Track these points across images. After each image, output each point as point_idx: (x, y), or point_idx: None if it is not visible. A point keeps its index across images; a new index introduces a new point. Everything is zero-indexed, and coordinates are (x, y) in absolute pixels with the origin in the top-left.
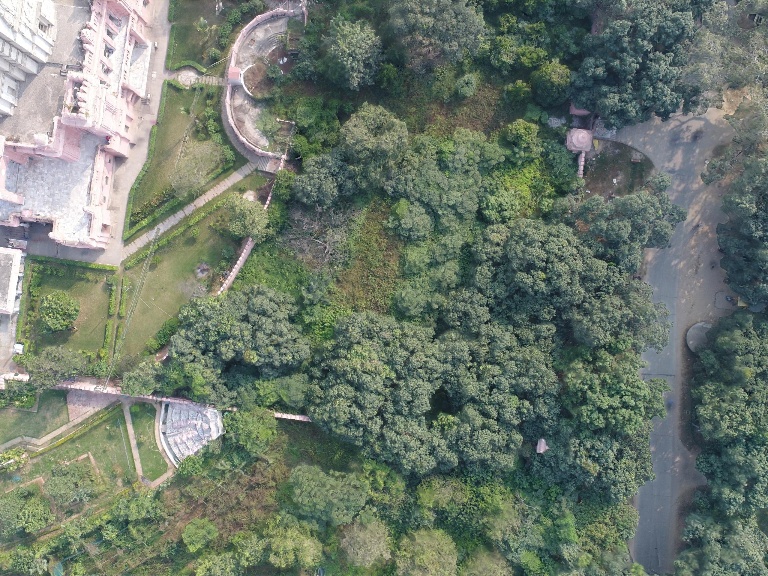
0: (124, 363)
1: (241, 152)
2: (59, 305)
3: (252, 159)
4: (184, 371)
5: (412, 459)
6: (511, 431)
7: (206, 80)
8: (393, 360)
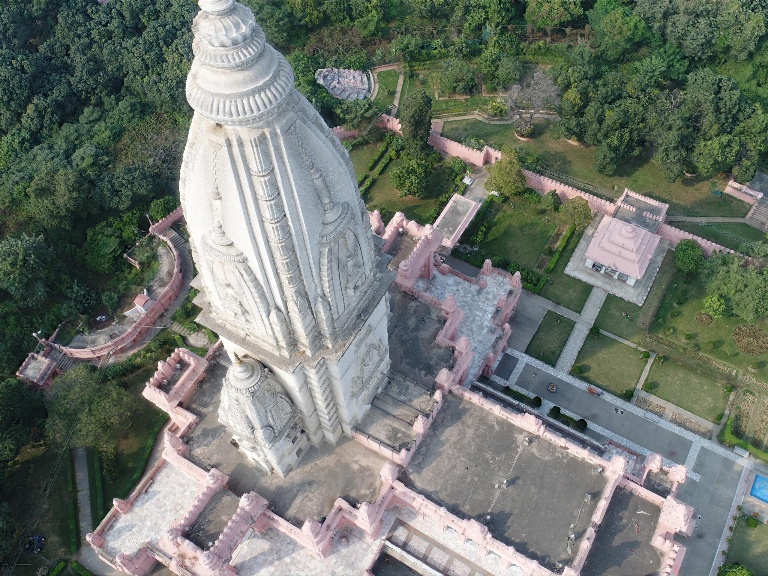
0: (373, 132)
1: (191, 260)
2: (400, 170)
3: (185, 251)
4: (313, 88)
5: (183, 0)
6: (114, 7)
7: (183, 331)
8: (158, 57)
